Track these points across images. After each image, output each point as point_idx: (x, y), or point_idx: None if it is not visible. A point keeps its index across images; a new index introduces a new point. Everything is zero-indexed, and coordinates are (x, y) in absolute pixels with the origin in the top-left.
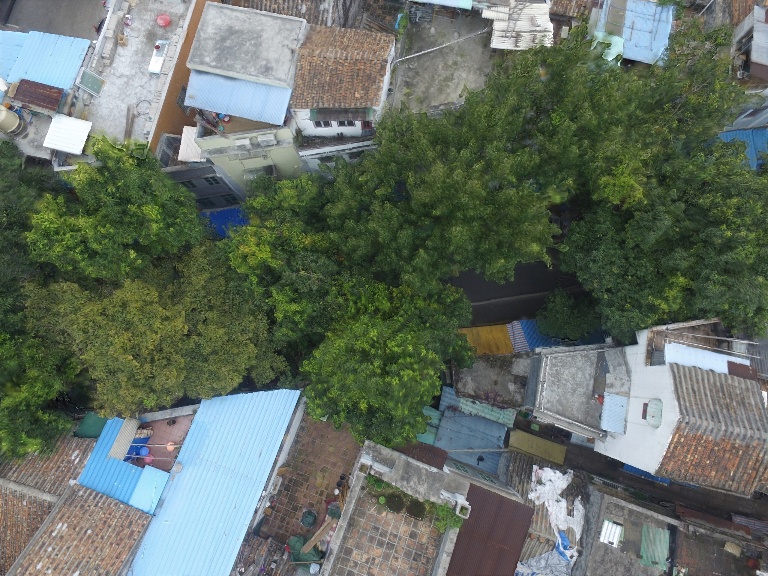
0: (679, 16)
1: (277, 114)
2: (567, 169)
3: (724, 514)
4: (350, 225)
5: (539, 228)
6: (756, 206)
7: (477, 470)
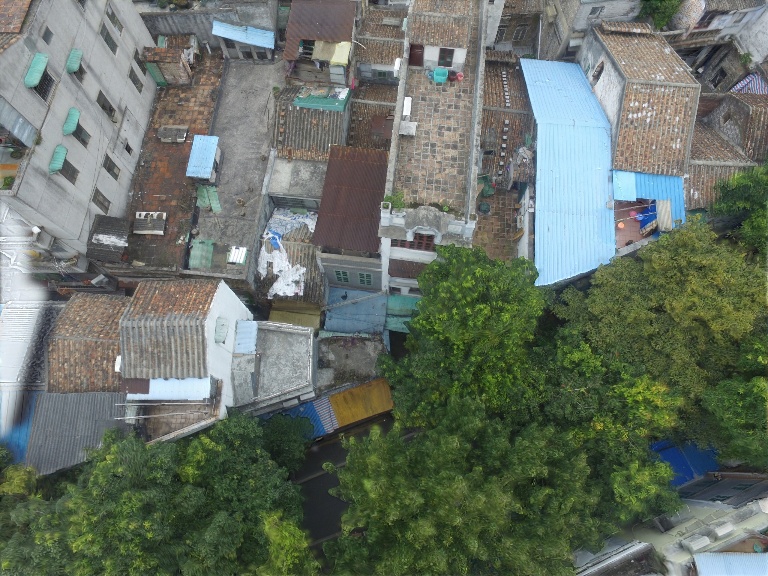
0: None
1: (708, 569)
2: (337, 571)
3: None
4: (556, 451)
5: (372, 460)
6: (111, 570)
7: (348, 285)
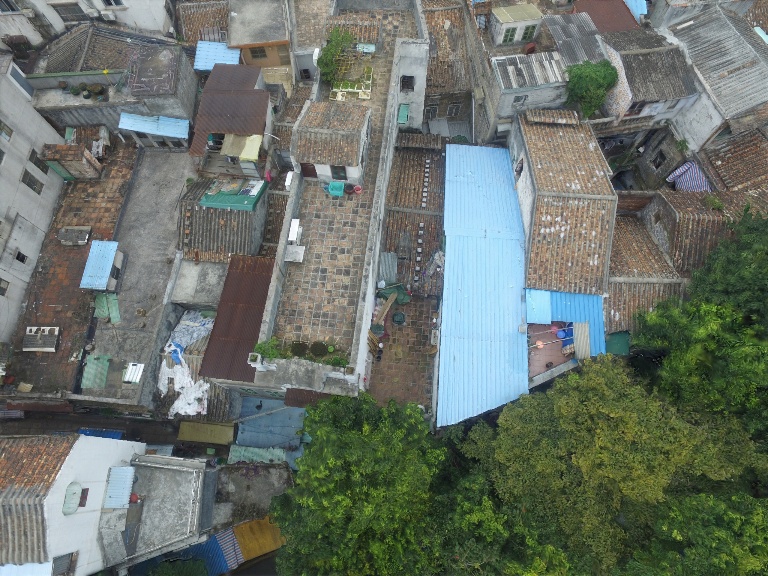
0: None
1: None
2: None
3: (32, 415)
4: None
5: None
6: None
7: (261, 396)
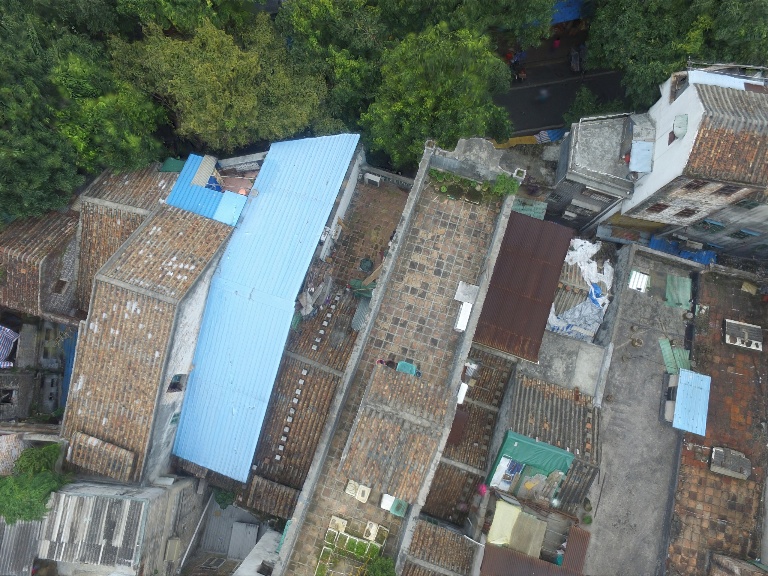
0: None
1: None
2: None
3: None
4: None
5: None
6: None
7: None
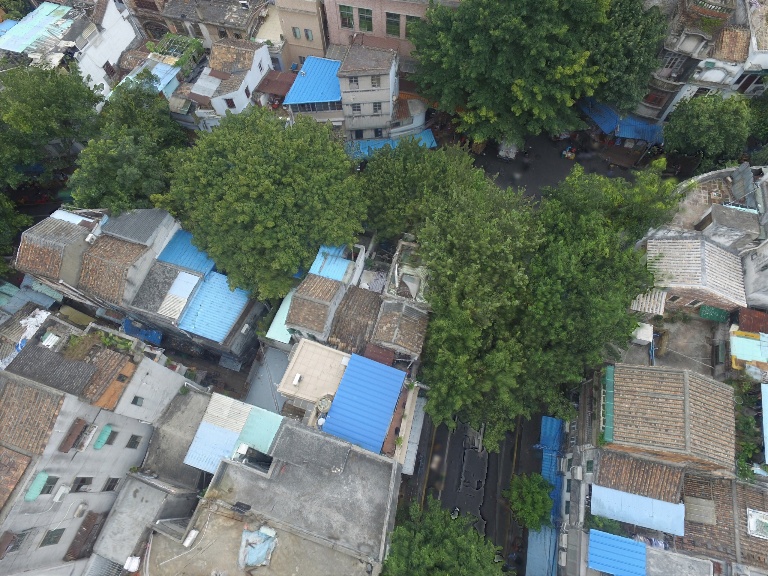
0: (185, 73)
1: None
2: None
3: None
4: None
5: None
6: None
7: None
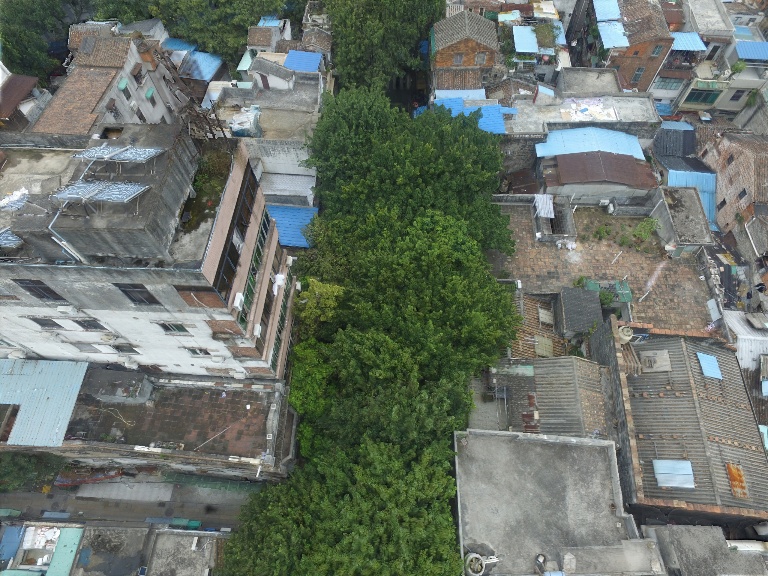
0: None
1: None
2: None
3: None
4: None
5: None
6: None
7: None
